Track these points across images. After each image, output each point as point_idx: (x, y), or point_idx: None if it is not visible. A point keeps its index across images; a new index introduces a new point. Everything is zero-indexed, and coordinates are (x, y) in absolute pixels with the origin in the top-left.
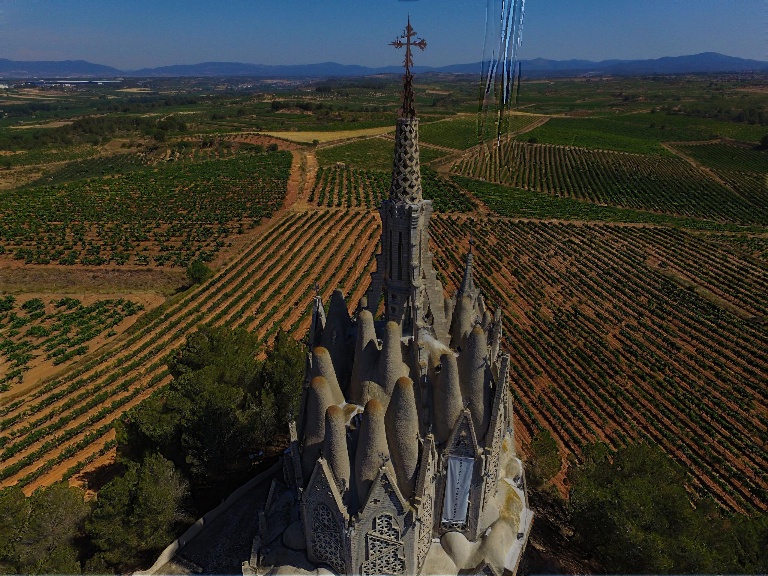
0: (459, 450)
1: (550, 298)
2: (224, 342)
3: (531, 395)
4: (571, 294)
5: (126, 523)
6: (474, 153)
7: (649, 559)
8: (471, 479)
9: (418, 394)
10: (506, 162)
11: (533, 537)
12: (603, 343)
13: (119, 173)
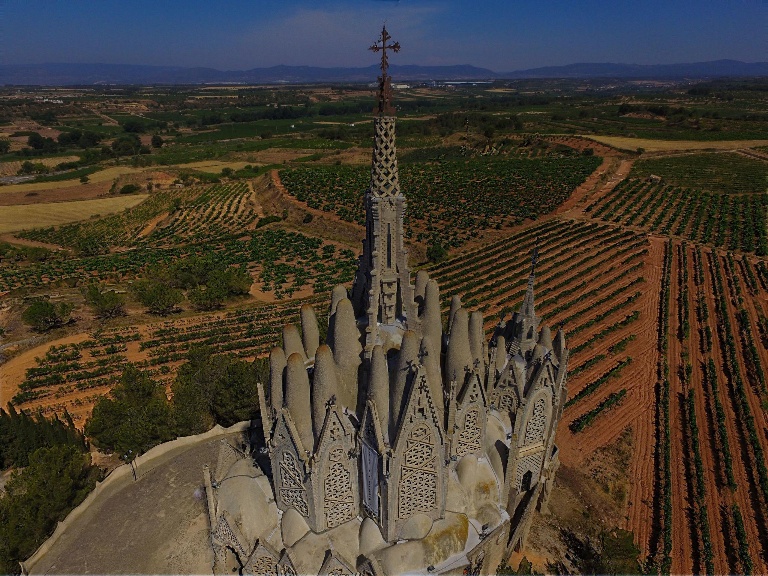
0: (370, 439)
1: None
2: None
3: None
4: None
5: None
6: None
7: None
8: (377, 473)
9: (362, 374)
10: None
11: None
12: None
13: (438, 161)
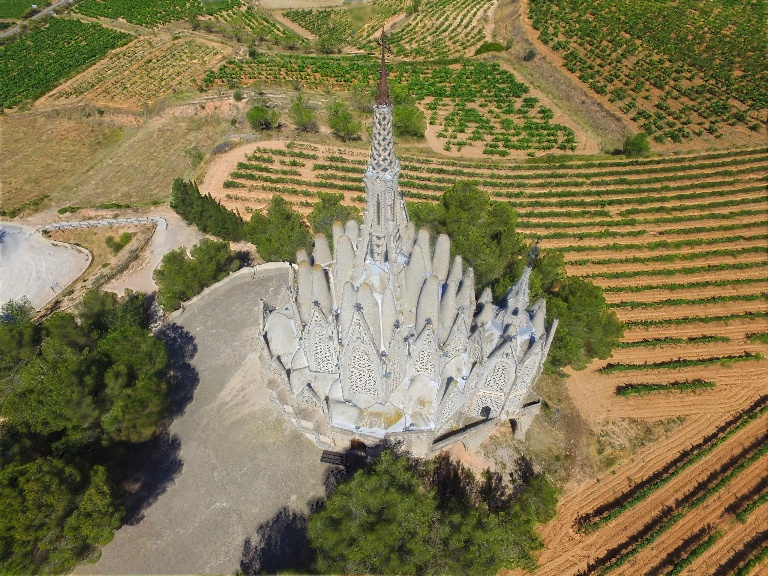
0: None
1: None
2: (468, 202)
3: None
4: None
5: None
6: None
7: None
8: None
9: None
10: None
11: (433, 486)
12: None
13: None
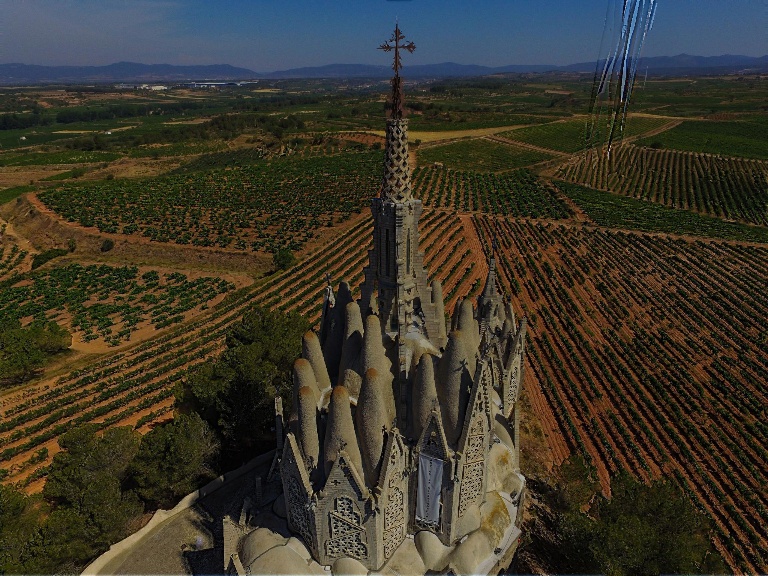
0: (430, 450)
1: (635, 318)
2: (274, 323)
3: (585, 417)
4: (661, 316)
5: (160, 467)
6: (581, 157)
7: None
8: (442, 481)
9: (398, 389)
10: (617, 168)
11: (538, 561)
12: (686, 374)
13: (238, 166)
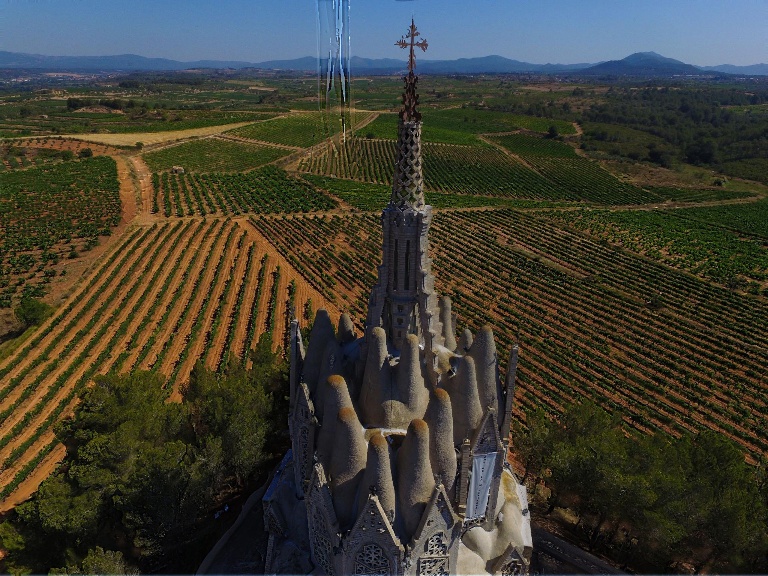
0: (482, 448)
1: None
2: (134, 391)
3: None
4: (448, 278)
5: None
6: None
7: (635, 498)
8: (493, 472)
9: None
10: (354, 158)
11: None
12: (489, 318)
13: None
